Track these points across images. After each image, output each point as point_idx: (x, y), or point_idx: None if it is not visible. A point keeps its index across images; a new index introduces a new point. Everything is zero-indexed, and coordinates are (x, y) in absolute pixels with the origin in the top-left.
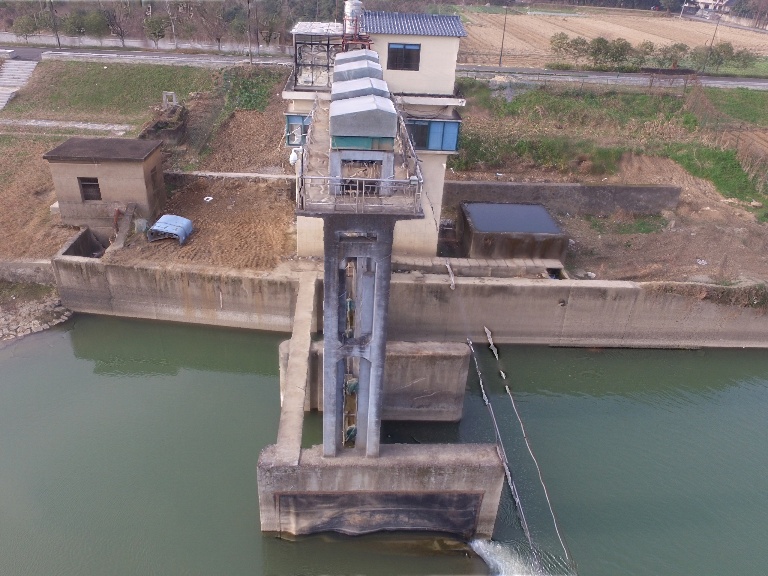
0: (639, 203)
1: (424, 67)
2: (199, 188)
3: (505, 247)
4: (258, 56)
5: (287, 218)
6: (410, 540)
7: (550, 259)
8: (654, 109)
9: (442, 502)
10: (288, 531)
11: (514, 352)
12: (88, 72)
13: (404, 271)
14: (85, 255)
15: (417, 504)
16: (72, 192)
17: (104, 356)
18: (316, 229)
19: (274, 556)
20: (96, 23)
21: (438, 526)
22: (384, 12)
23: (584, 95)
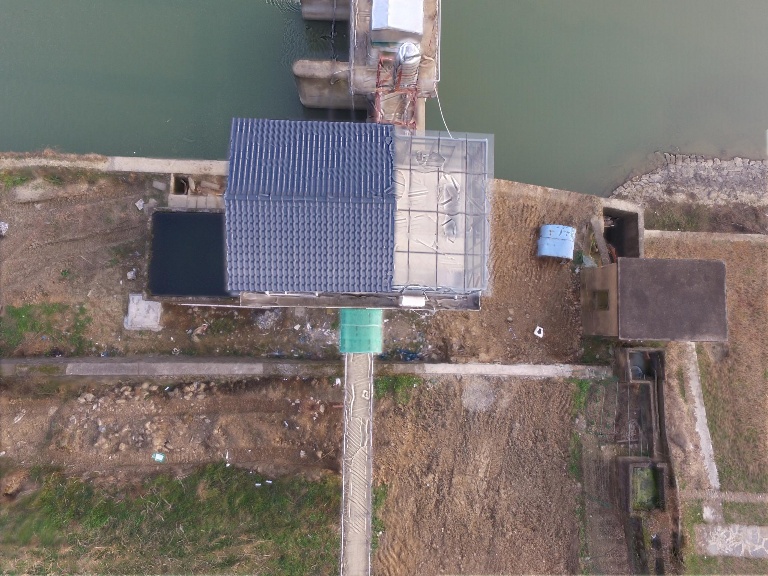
0: None
1: None
2: (556, 356)
3: None
4: None
5: None
6: None
7: None
8: None
9: None
10: None
11: None
12: None
13: None
14: (626, 256)
15: None
16: None
17: None
18: None
19: None
20: None
21: None
22: (352, 197)
23: None
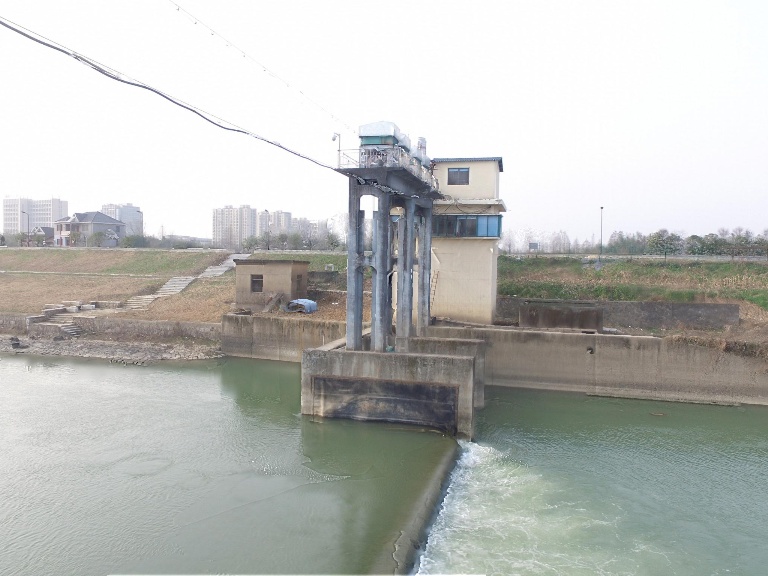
0: (699, 318)
1: (473, 182)
2: (331, 300)
3: (548, 318)
4: None
5: None
6: None
7: None
8: (738, 273)
9: (428, 394)
10: (319, 414)
11: (553, 397)
12: (281, 258)
13: None
14: None
15: (410, 395)
16: (246, 285)
17: (240, 394)
18: None
19: (308, 441)
20: (295, 239)
21: (426, 419)
22: None
23: (669, 266)
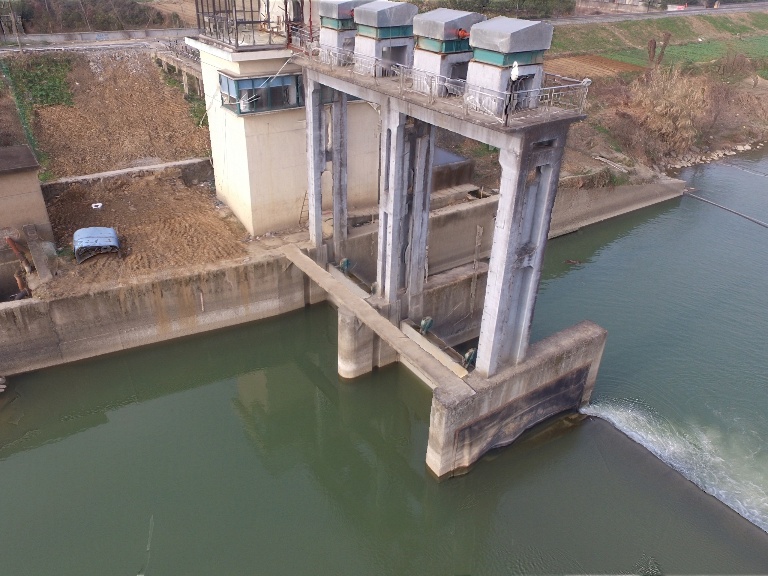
0: None
1: None
2: (74, 197)
3: None
4: (6, 46)
5: (207, 204)
6: (547, 429)
7: (464, 184)
8: None
9: (566, 383)
10: (461, 466)
11: None
12: None
13: (362, 224)
14: None
15: (551, 393)
16: None
17: (52, 420)
18: (270, 202)
19: (446, 499)
20: None
21: (562, 407)
22: None
23: None
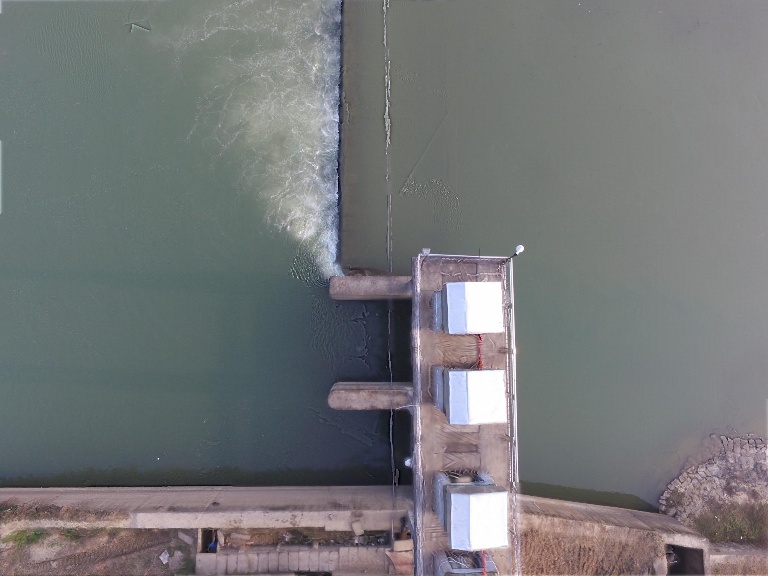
0: None
1: None
2: None
3: None
4: None
5: None
6: None
7: (206, 574)
8: None
9: None
10: None
11: (267, 480)
12: None
13: (369, 544)
14: None
15: None
16: None
17: None
18: None
19: None
20: None
21: None
22: None
23: None
